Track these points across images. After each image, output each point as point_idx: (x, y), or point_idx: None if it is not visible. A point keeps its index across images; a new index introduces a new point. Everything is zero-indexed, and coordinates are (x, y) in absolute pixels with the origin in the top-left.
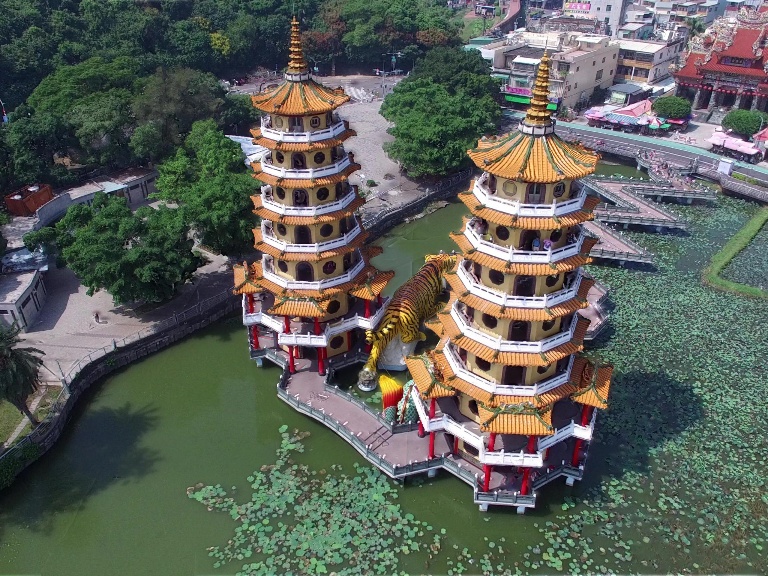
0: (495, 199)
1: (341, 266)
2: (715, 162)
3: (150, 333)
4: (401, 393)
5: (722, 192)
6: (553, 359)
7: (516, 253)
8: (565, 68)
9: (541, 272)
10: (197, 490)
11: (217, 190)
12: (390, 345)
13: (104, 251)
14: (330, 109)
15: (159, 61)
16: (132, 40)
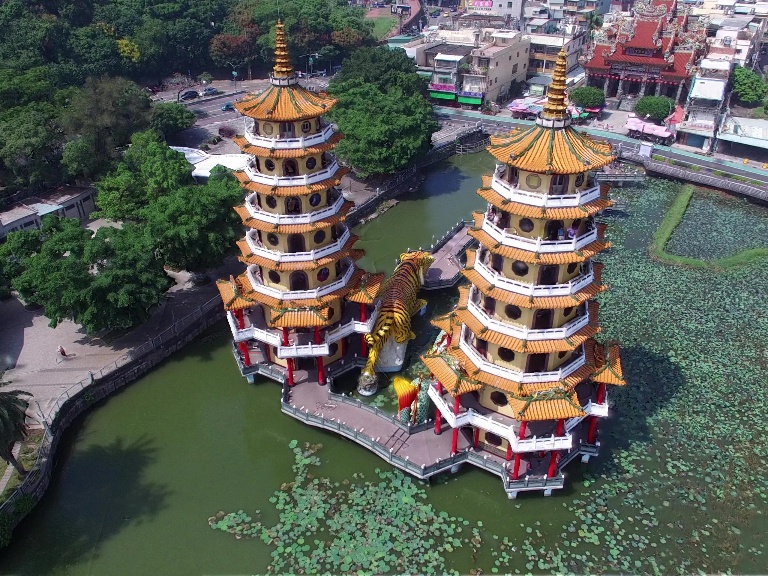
0: (520, 193)
1: (334, 272)
2: (636, 146)
3: (127, 361)
4: (415, 393)
5: (646, 173)
6: (578, 343)
7: (543, 244)
8: (485, 63)
9: (569, 260)
10: (219, 519)
11: (182, 204)
12: (385, 347)
13: (72, 278)
14: None
15: (65, 71)
16: (31, 50)
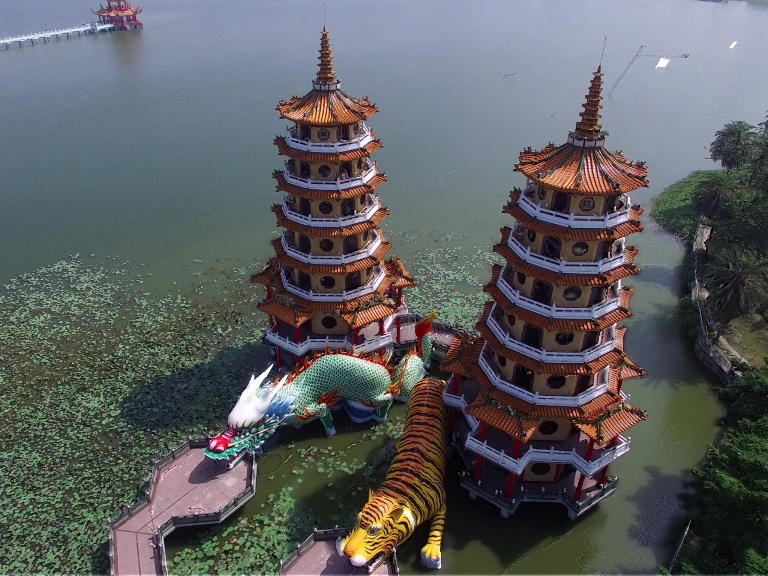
0: None
1: None
2: None
3: None
4: None
5: None
6: None
7: None
8: None
9: None
10: None
11: None
12: None
13: None
14: None
15: None
16: None
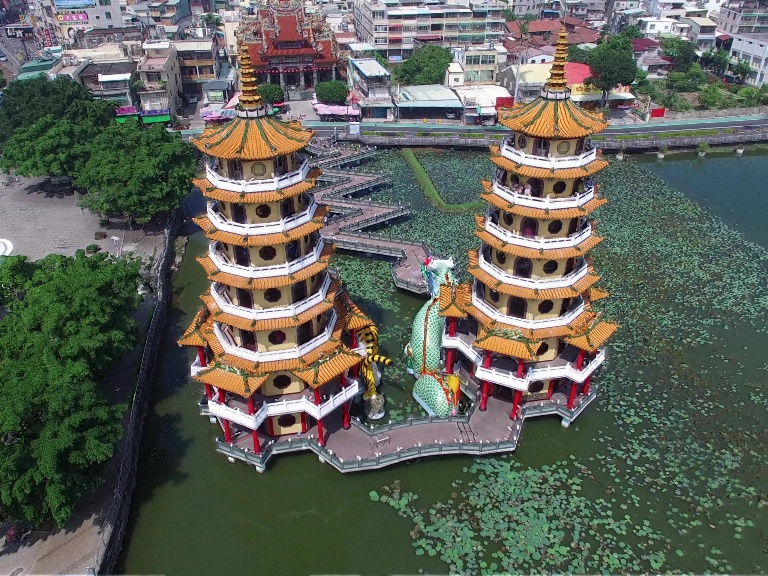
0: (560, 160)
1: None
2: (346, 127)
3: (108, 532)
4: None
5: None
6: None
7: (580, 198)
8: (156, 78)
9: (597, 205)
10: None
11: (63, 309)
12: None
13: (15, 460)
14: None
15: None
16: None
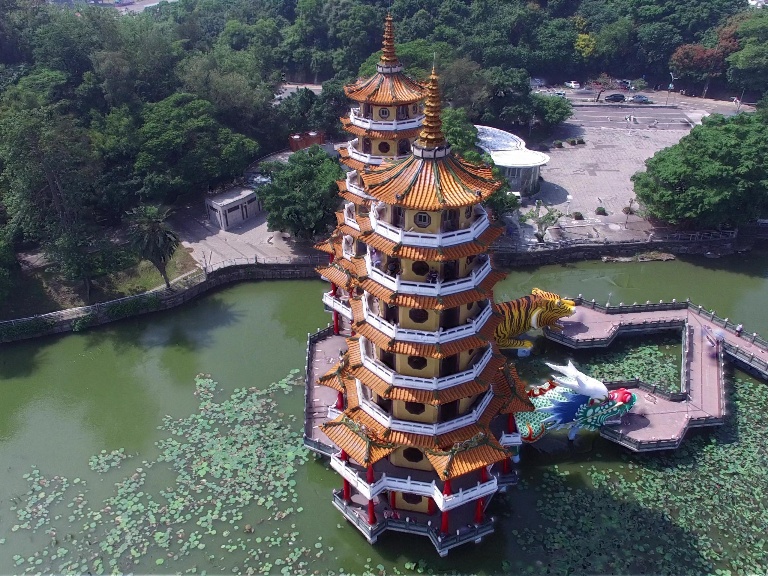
0: None
1: None
2: None
3: (287, 262)
4: None
5: None
6: (398, 396)
7: (375, 270)
8: None
9: (382, 297)
10: (203, 378)
11: None
12: None
13: (272, 186)
14: (390, 103)
15: (514, 53)
16: (502, 31)
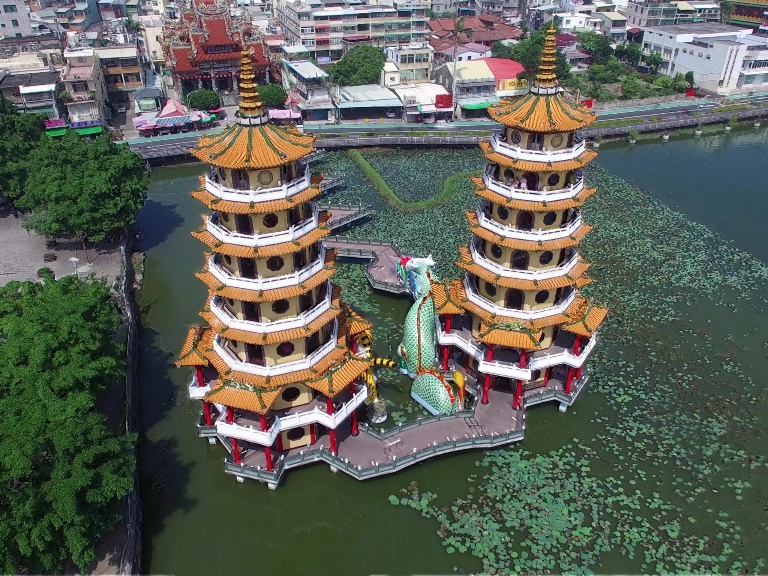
0: (555, 153)
1: None
2: None
3: (128, 571)
4: None
5: None
6: None
7: None
8: (82, 87)
9: (588, 195)
10: None
11: (51, 339)
12: None
13: None
14: None
15: None
16: None
